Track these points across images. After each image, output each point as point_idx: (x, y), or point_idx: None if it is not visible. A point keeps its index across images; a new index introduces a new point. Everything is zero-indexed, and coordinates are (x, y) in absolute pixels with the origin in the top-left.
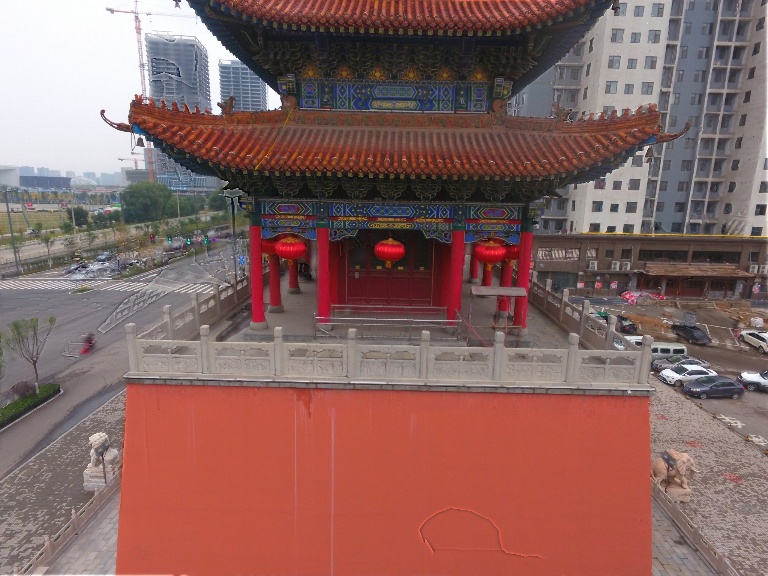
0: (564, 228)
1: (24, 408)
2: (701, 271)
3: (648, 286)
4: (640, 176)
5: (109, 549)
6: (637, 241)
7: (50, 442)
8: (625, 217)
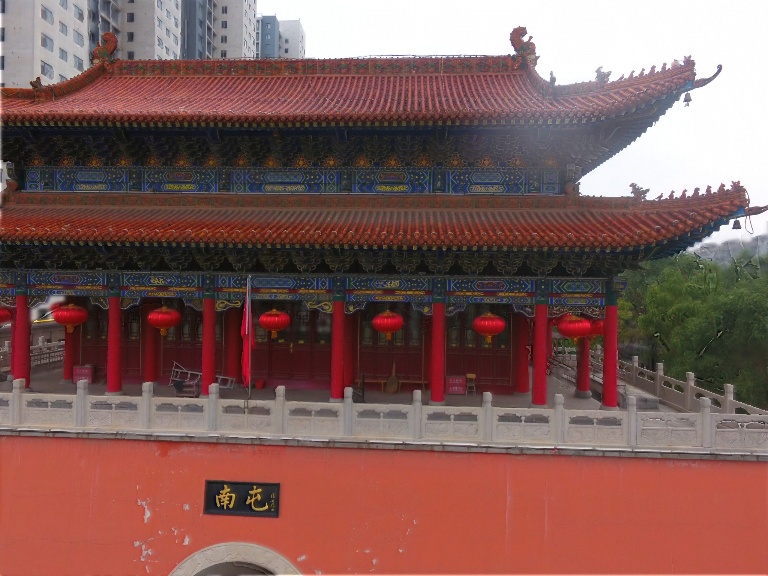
0: None
1: None
2: None
3: None
4: None
5: None
6: None
7: None
8: None
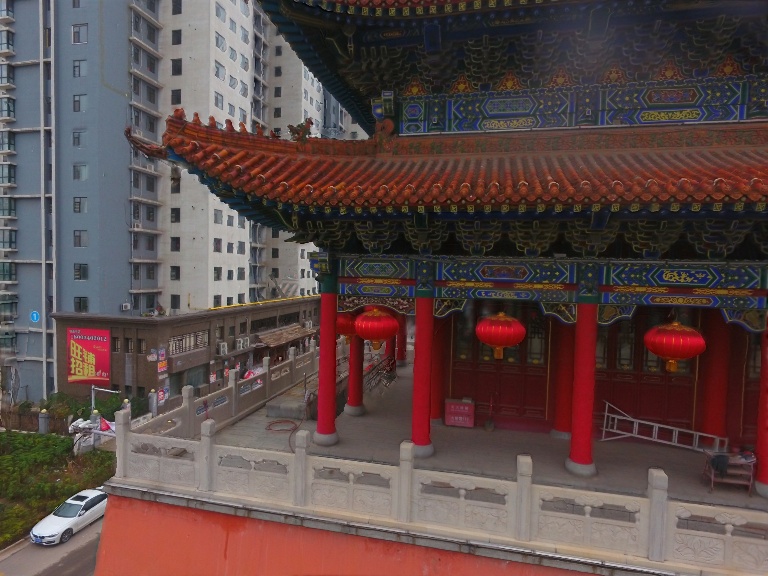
0: (156, 305)
1: None
2: (291, 334)
3: (256, 360)
4: (244, 239)
5: None
6: (250, 312)
7: None
8: (238, 285)
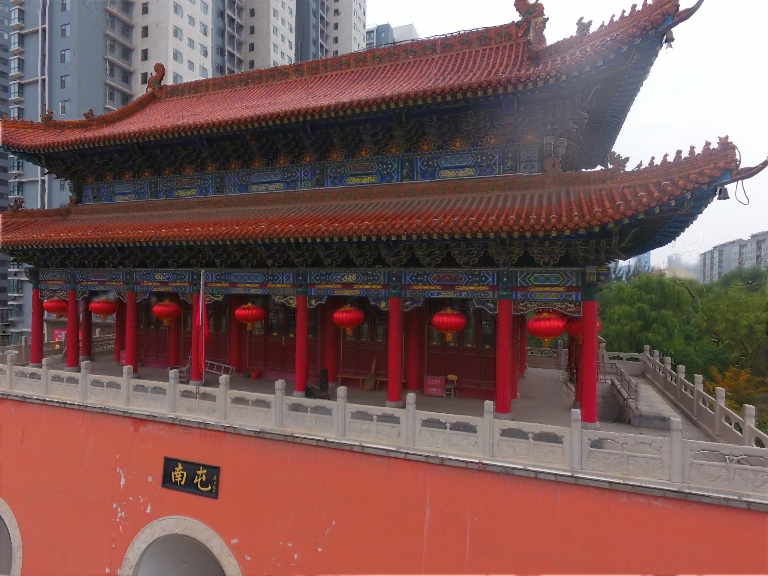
0: None
1: None
2: None
3: None
4: None
5: None
6: None
7: None
8: None
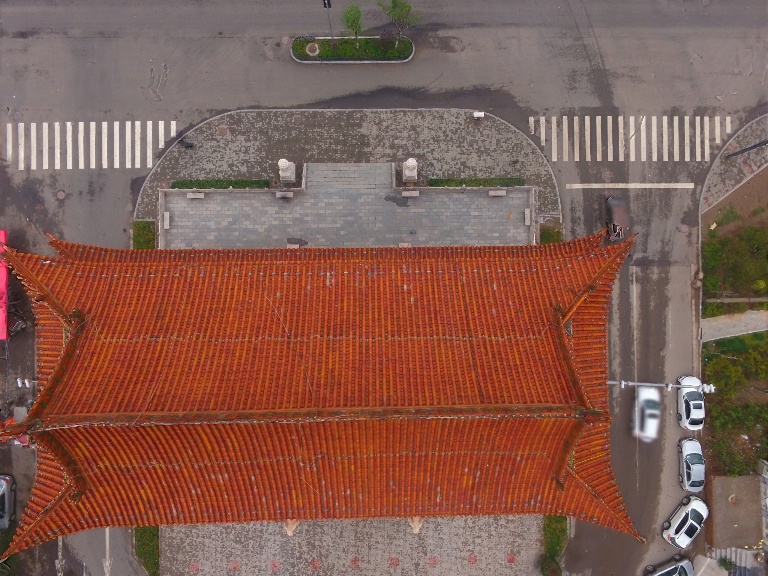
0: None
1: (367, 58)
2: None
3: None
4: None
5: (223, 214)
6: None
7: (331, 107)
8: None
